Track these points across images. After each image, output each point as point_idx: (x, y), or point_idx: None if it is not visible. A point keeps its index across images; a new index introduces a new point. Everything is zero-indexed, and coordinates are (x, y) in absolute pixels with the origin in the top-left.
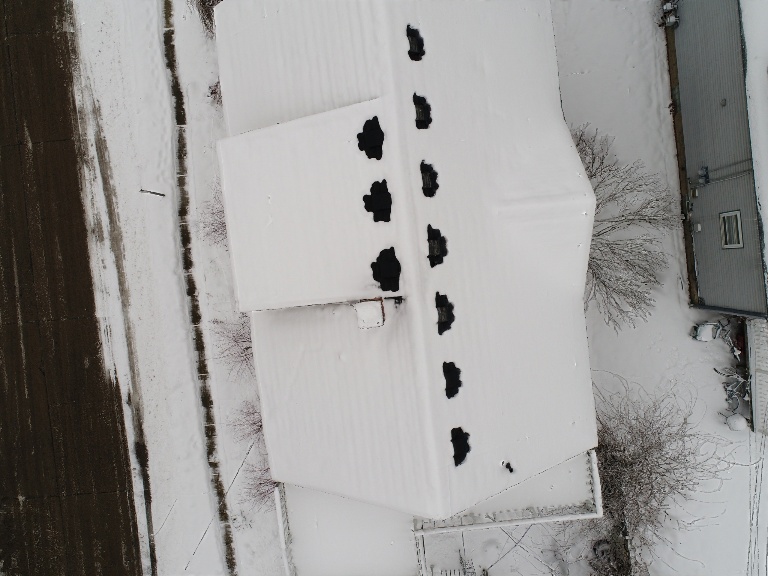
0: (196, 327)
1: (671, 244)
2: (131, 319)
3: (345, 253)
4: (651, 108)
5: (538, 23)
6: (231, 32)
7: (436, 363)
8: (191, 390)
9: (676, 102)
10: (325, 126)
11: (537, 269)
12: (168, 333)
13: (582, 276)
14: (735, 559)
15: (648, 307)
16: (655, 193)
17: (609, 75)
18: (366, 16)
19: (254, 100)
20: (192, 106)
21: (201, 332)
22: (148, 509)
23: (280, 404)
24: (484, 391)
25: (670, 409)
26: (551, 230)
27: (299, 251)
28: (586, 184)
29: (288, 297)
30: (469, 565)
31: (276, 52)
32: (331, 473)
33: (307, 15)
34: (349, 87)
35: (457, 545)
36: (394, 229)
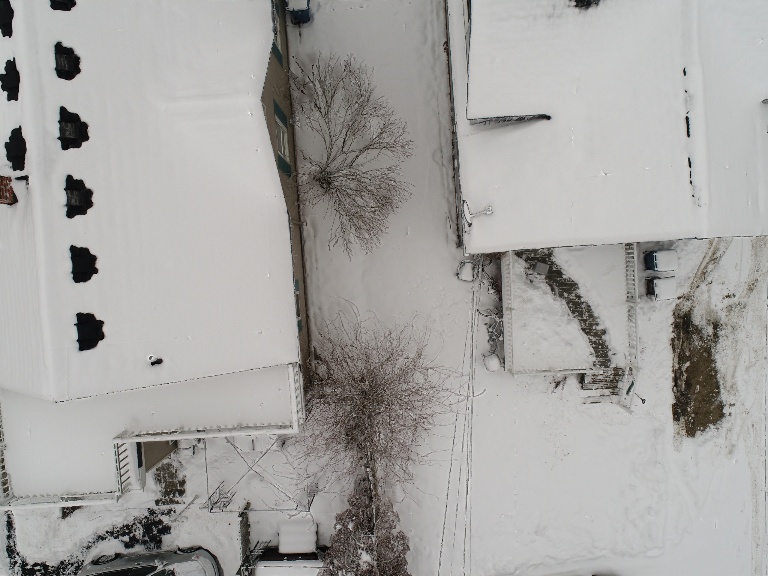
0: None
1: (440, 183)
2: None
3: None
4: (426, 45)
5: None
6: None
7: (60, 245)
8: None
9: None
10: None
11: (219, 173)
12: None
13: (274, 186)
14: (495, 503)
15: (417, 245)
16: (384, 117)
17: (386, 10)
18: None
19: None
20: None
21: None
22: None
23: None
24: (129, 283)
25: (408, 340)
26: (224, 131)
27: None
28: (255, 85)
29: None
30: (226, 495)
31: None
32: None
33: None
34: None
35: (222, 476)
36: (19, 107)
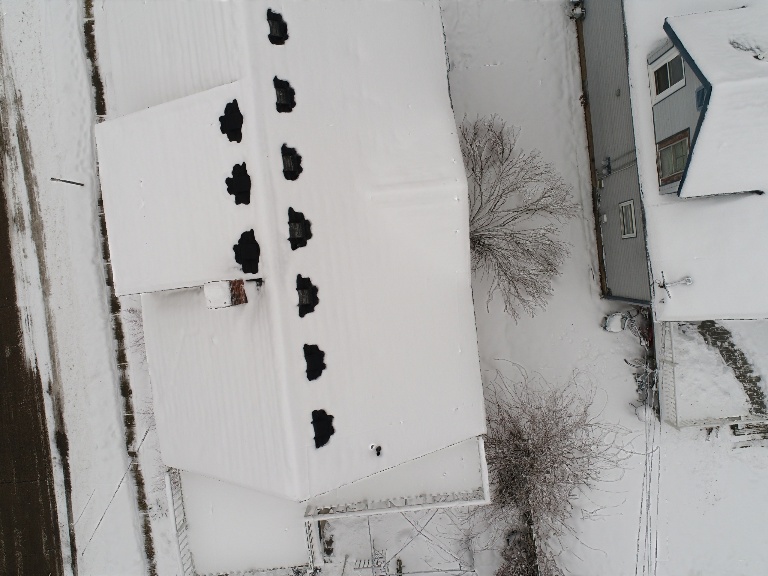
0: (115, 316)
1: (582, 235)
2: (51, 308)
3: (209, 236)
4: (562, 100)
5: (423, 11)
6: (118, 18)
7: (295, 345)
8: (109, 379)
9: (586, 94)
10: (190, 109)
11: (416, 255)
12: (86, 322)
13: (465, 263)
14: None
15: (560, 298)
16: (550, 182)
17: (521, 67)
18: None
19: (138, 86)
20: (109, 96)
21: (120, 321)
22: (68, 498)
23: (167, 389)
24: (352, 374)
25: (572, 398)
26: (426, 216)
27: (168, 234)
28: (459, 170)
29: (159, 280)
30: (381, 555)
31: (155, 37)
32: (208, 457)
33: None
34: (214, 71)
35: (371, 535)
36: (253, 211)
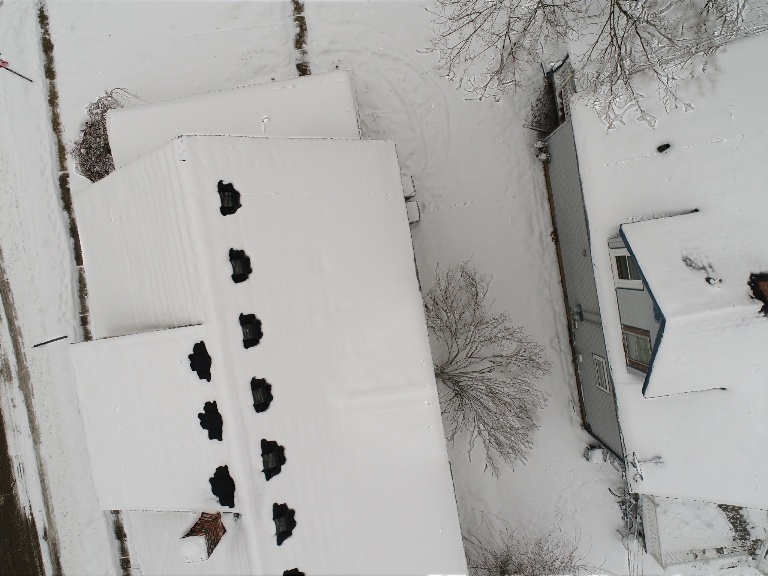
0: None
1: (560, 368)
2: (43, 456)
3: (186, 467)
4: (533, 236)
5: (386, 202)
6: (88, 225)
7: (275, 575)
8: (103, 526)
9: (556, 231)
10: (159, 345)
11: (392, 449)
12: (77, 471)
13: (441, 447)
14: None
15: (542, 430)
16: (522, 344)
17: (491, 206)
18: (187, 246)
19: (110, 294)
20: None
21: None
22: None
23: None
24: None
25: (557, 543)
26: (399, 416)
27: (146, 460)
28: (428, 373)
29: (139, 503)
30: None
31: (123, 255)
32: None
33: (143, 229)
34: (181, 306)
35: None
36: (225, 450)
